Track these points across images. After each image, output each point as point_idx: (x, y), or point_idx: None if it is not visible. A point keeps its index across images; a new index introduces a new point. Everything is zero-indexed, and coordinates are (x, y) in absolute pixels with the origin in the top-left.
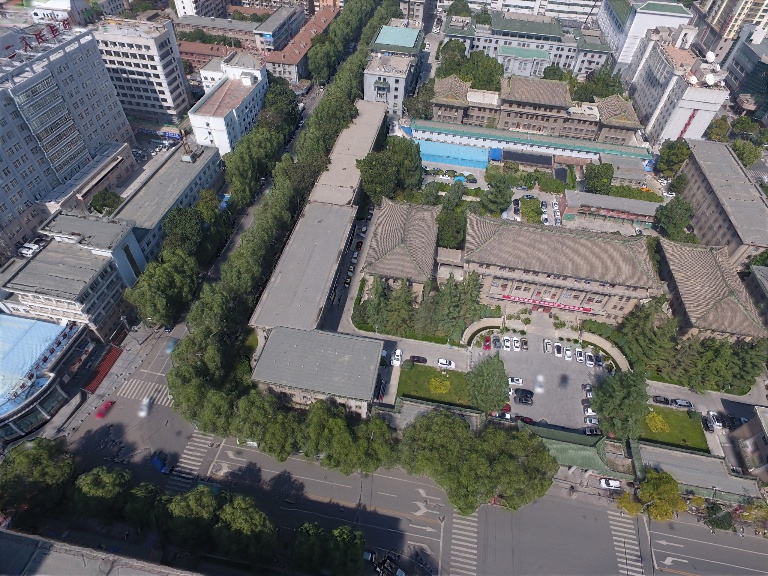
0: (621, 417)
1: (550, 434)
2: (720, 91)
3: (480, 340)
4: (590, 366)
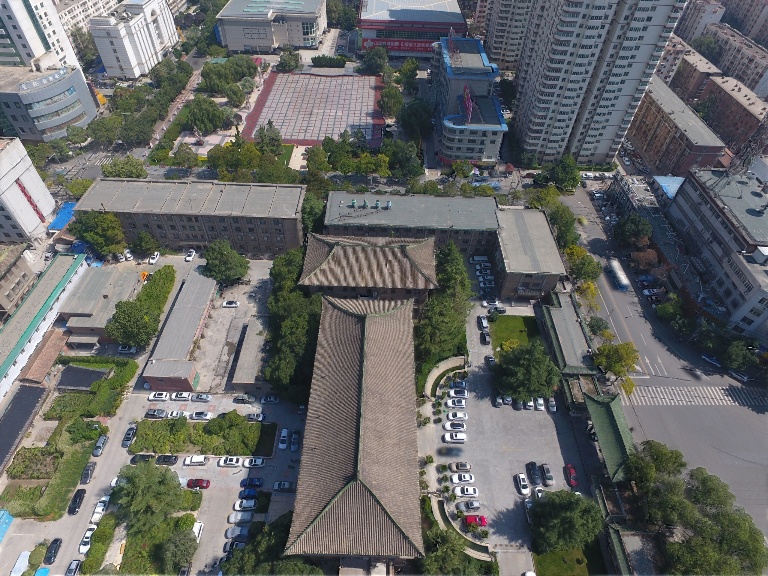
0: (547, 375)
1: (609, 446)
2: (11, 145)
3: (473, 532)
4: (468, 395)
